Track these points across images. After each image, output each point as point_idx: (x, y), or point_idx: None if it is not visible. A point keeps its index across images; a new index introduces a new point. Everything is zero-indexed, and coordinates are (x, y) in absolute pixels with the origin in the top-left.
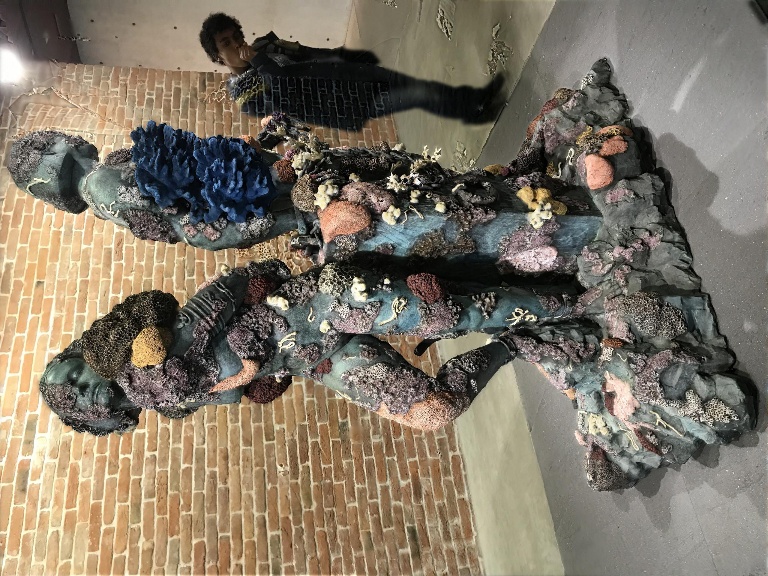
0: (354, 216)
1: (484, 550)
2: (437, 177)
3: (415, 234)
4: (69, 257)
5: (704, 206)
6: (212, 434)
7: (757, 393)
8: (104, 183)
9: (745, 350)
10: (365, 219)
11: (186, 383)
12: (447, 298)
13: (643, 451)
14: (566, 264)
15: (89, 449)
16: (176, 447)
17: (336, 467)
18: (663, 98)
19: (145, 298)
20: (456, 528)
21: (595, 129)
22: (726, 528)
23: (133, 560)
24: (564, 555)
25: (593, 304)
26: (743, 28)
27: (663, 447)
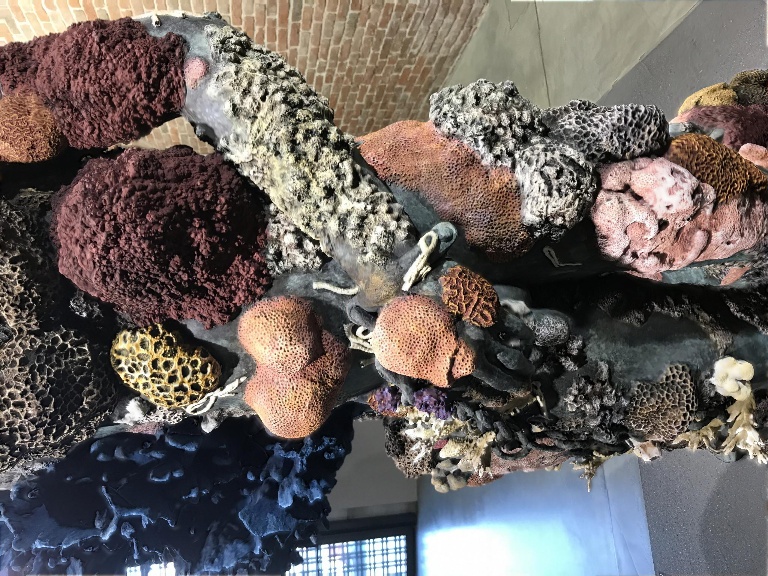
0: None
1: None
2: None
3: None
4: None
5: None
6: None
7: None
8: None
9: None
10: None
11: None
12: None
13: None
14: None
15: None
16: None
17: None
18: None
19: None
20: None
21: None
22: None
23: None
24: (628, 81)
25: None
26: None
27: None
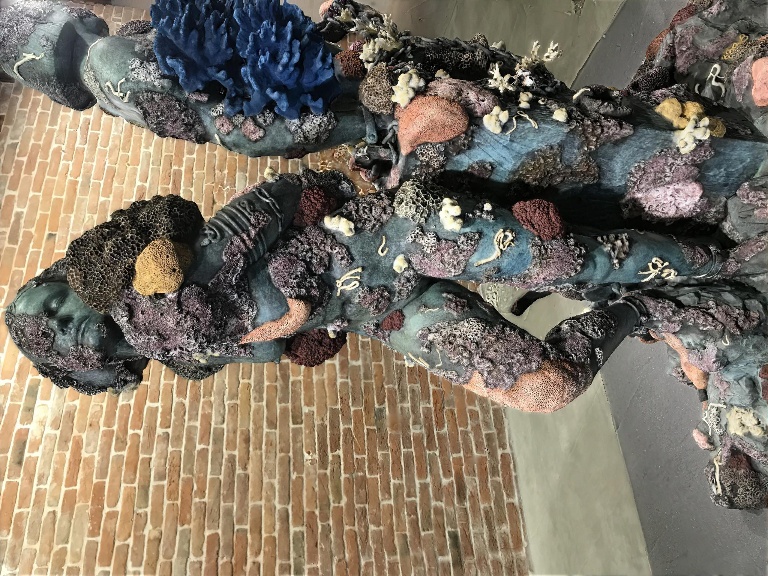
0: (448, 115)
1: (536, 564)
2: (551, 81)
3: (523, 150)
4: (85, 209)
5: None
6: (233, 413)
7: None
8: (112, 53)
9: None
10: (461, 121)
11: (209, 324)
12: (567, 235)
13: None
14: (710, 209)
15: (95, 421)
16: (192, 425)
17: (370, 458)
18: None
19: (158, 203)
20: (504, 536)
21: (752, 38)
22: None
23: (137, 550)
24: None
25: (753, 260)
26: None
27: None
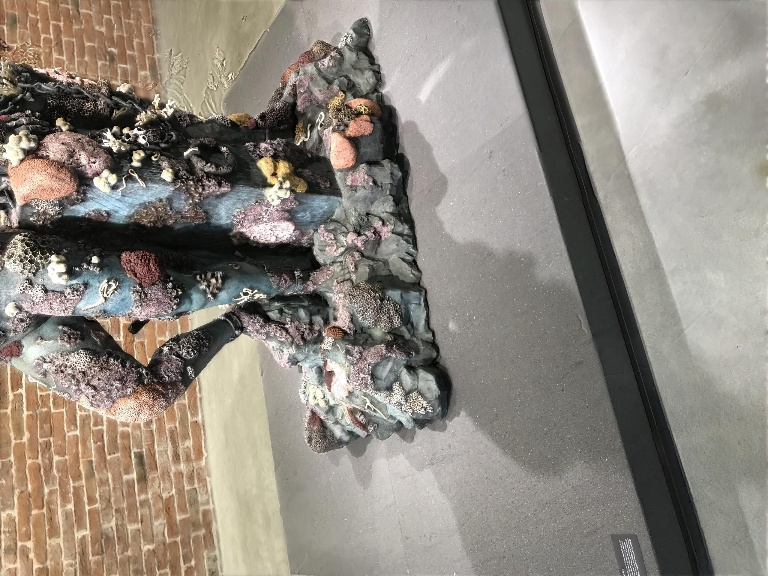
0: (55, 181)
1: (213, 471)
2: (168, 134)
3: (135, 202)
4: None
5: (433, 205)
6: None
7: (451, 387)
8: None
9: (447, 347)
10: (70, 185)
11: None
12: (167, 279)
13: (353, 424)
14: (303, 237)
15: None
16: None
17: None
18: (412, 83)
19: None
20: (186, 450)
21: (347, 97)
22: (412, 495)
23: None
24: (281, 494)
25: (323, 284)
26: (488, 40)
27: (369, 426)
